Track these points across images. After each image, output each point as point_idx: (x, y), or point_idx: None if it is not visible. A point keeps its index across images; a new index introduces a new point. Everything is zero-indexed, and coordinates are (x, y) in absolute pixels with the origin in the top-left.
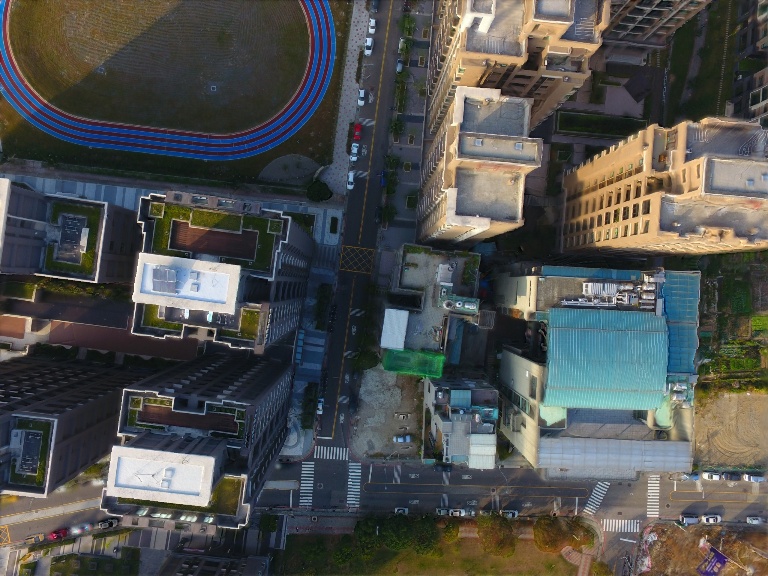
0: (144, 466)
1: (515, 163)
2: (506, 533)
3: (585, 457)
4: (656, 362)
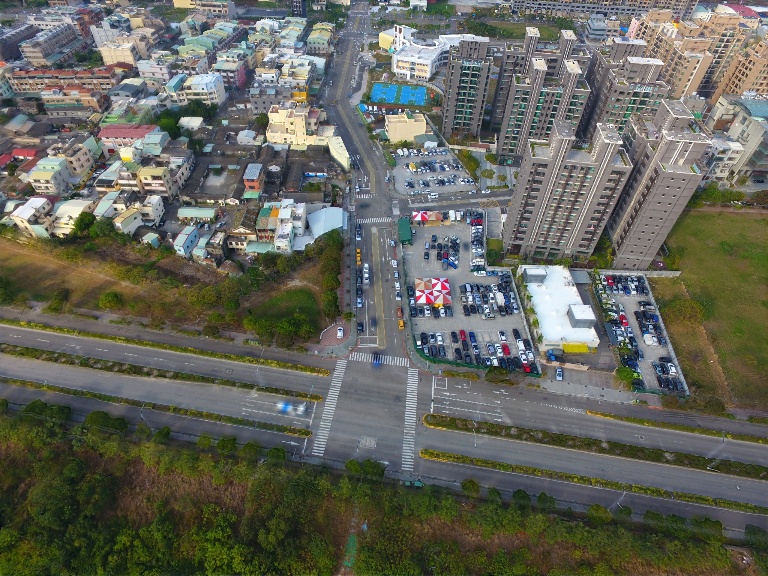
0: (639, 59)
1: (705, 39)
2: None
3: None
4: None
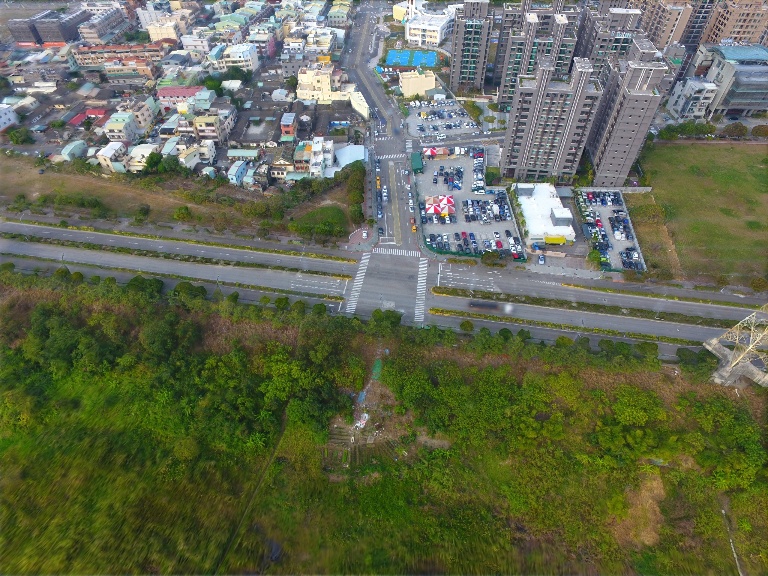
0: None
1: None
2: (739, 122)
3: (752, 67)
4: (760, 50)
